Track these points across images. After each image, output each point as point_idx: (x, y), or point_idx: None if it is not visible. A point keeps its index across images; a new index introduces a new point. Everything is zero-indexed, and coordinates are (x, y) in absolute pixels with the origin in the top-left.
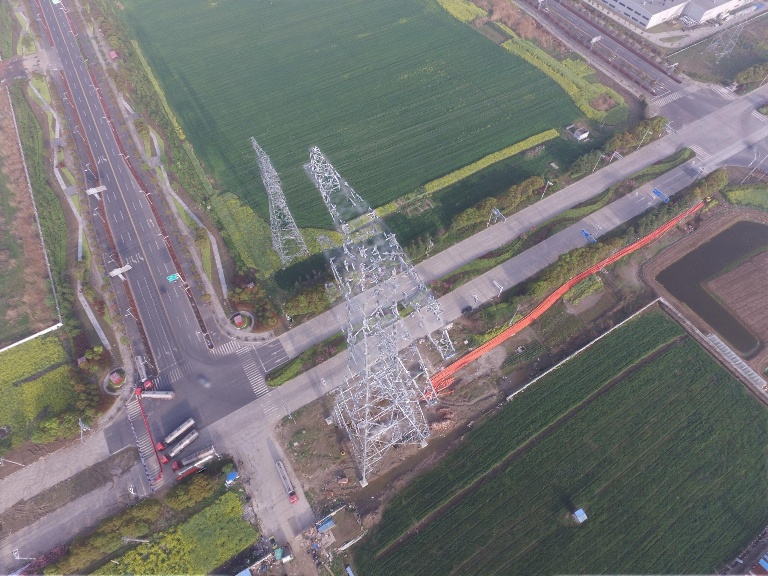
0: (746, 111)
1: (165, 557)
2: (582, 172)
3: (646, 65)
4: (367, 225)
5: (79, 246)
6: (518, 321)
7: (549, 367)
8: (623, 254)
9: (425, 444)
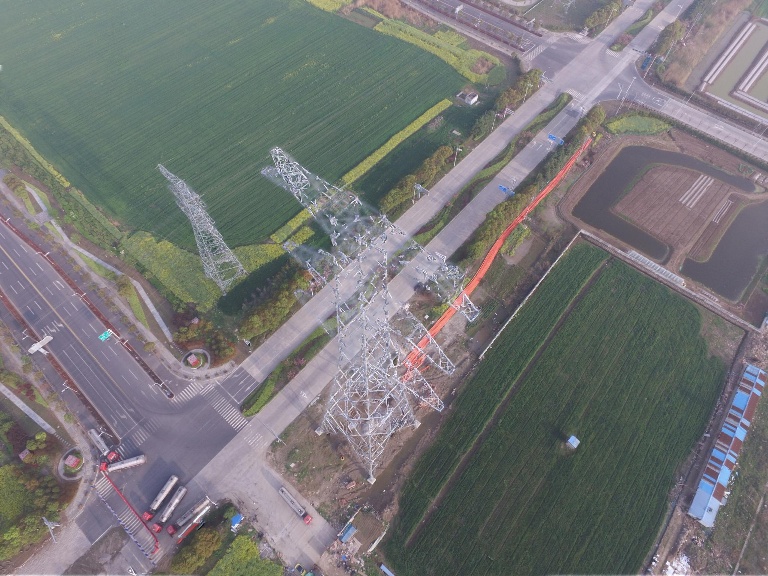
0: (601, 51)
1: None
2: (483, 133)
3: (508, 25)
4: (297, 230)
5: None
6: (467, 284)
7: (507, 318)
8: (539, 199)
9: (418, 424)
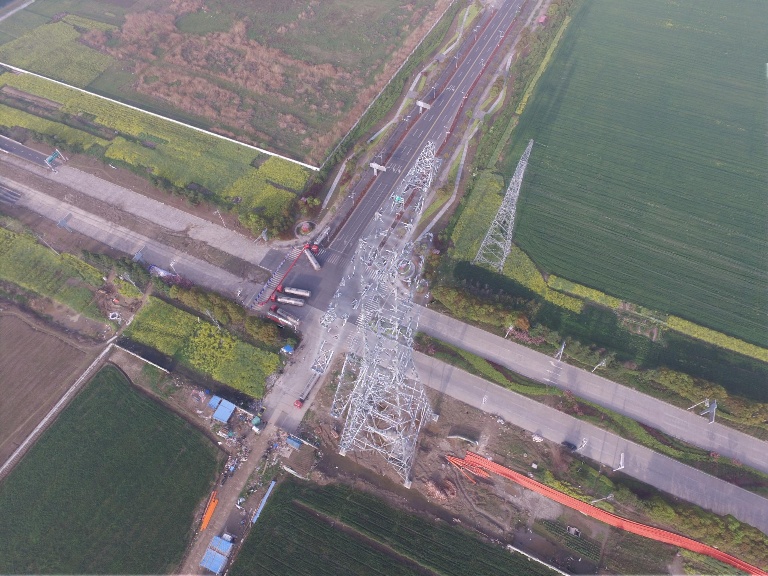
0: None
1: (216, 347)
2: None
3: None
4: (574, 296)
5: (378, 133)
6: (604, 510)
7: None
8: None
9: (408, 486)
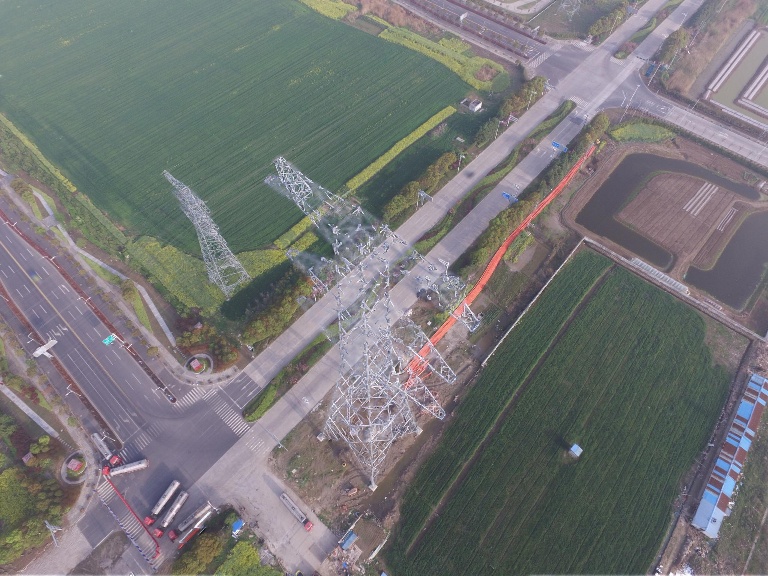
0: (605, 59)
1: None
2: (486, 140)
3: (512, 33)
4: (301, 235)
5: None
6: (470, 291)
7: (510, 325)
8: (543, 206)
9: (420, 431)
